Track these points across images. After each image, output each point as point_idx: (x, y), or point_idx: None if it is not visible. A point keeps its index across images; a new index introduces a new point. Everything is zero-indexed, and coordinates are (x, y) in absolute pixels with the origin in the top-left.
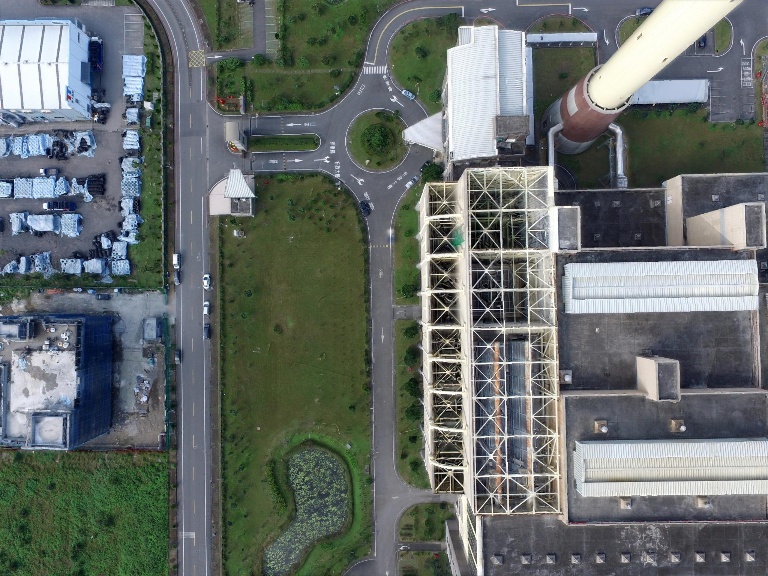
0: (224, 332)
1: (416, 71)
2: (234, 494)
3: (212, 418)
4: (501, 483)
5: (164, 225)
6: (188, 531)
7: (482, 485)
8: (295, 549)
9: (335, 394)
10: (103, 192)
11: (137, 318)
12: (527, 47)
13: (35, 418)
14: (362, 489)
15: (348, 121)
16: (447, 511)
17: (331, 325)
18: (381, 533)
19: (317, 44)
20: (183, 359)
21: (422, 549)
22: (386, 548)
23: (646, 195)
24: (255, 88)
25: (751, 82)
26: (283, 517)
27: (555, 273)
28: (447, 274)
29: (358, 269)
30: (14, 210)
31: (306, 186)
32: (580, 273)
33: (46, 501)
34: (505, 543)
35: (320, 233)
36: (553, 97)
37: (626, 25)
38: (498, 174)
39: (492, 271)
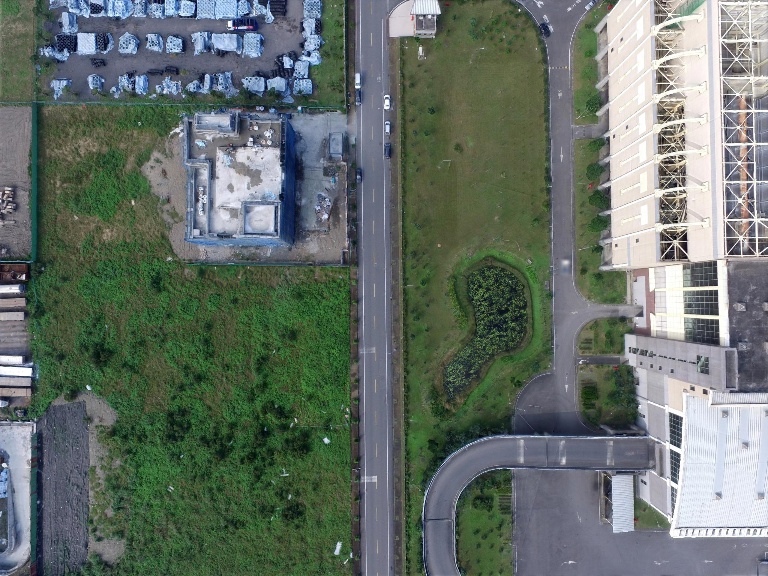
0: (405, 151)
1: None
2: (415, 310)
3: (392, 236)
4: (750, 226)
5: (345, 46)
6: (369, 346)
7: (732, 228)
8: (475, 364)
9: (515, 212)
10: (285, 13)
11: (318, 138)
12: None
13: (245, 208)
14: (542, 304)
15: None
16: (626, 325)
17: (511, 144)
18: (560, 347)
19: None
20: (363, 178)
21: (601, 362)
22: (565, 362)
23: None
24: None
25: None
26: (464, 332)
27: None
28: (672, 49)
29: (538, 90)
30: (196, 30)
31: (486, 8)
32: None
33: (228, 316)
34: (747, 291)
35: (500, 54)
36: None
37: None
38: None
39: (740, 22)
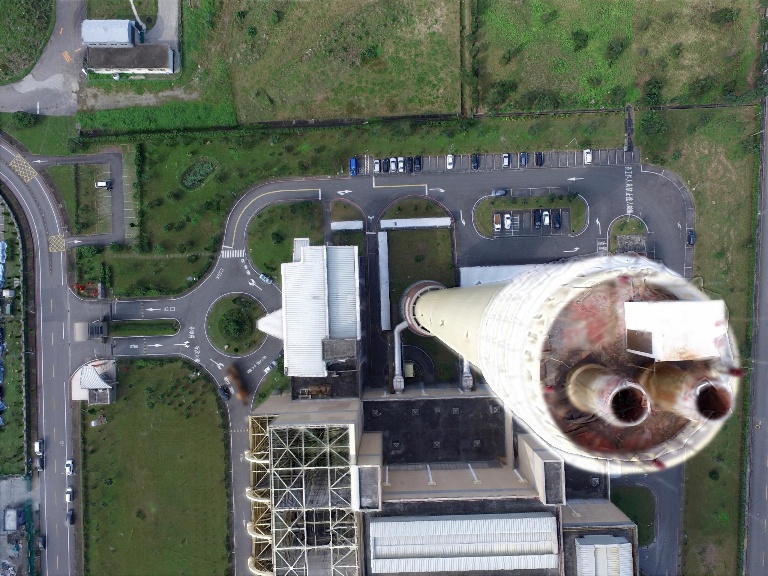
0: (87, 518)
1: (273, 255)
2: None
3: None
4: None
5: (26, 412)
6: None
7: None
8: None
9: None
10: None
11: (1, 504)
12: (382, 232)
13: None
14: None
15: (207, 305)
16: None
17: (193, 510)
18: None
19: (174, 229)
20: (48, 545)
21: None
22: None
23: (486, 401)
24: (114, 273)
25: None
26: None
27: (357, 531)
28: None
29: (219, 454)
30: None
31: (166, 371)
32: (380, 533)
33: None
34: None
35: (181, 418)
36: (410, 279)
37: (482, 206)
38: (300, 432)
39: (295, 529)
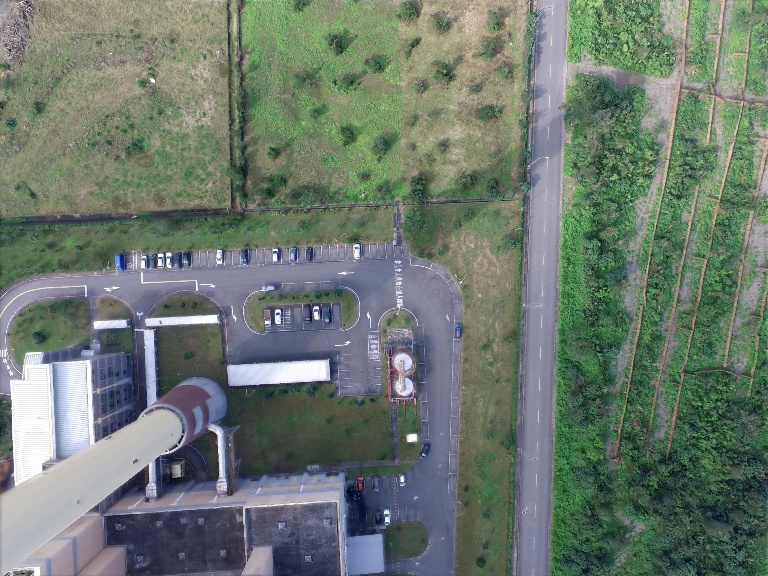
0: None
1: None
2: None
3: None
4: None
5: None
6: None
7: None
8: None
9: None
10: None
11: None
12: (148, 330)
13: None
14: None
15: None
16: None
17: None
18: None
19: None
20: None
21: None
22: None
23: (232, 509)
24: None
25: (378, 355)
26: None
27: None
28: None
29: None
30: None
31: None
32: None
33: None
34: None
35: None
36: (180, 376)
37: (253, 301)
38: None
39: None
